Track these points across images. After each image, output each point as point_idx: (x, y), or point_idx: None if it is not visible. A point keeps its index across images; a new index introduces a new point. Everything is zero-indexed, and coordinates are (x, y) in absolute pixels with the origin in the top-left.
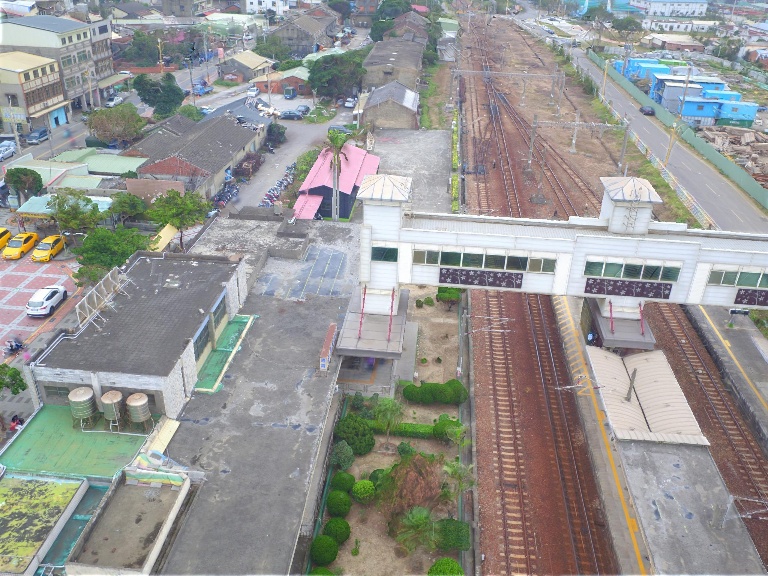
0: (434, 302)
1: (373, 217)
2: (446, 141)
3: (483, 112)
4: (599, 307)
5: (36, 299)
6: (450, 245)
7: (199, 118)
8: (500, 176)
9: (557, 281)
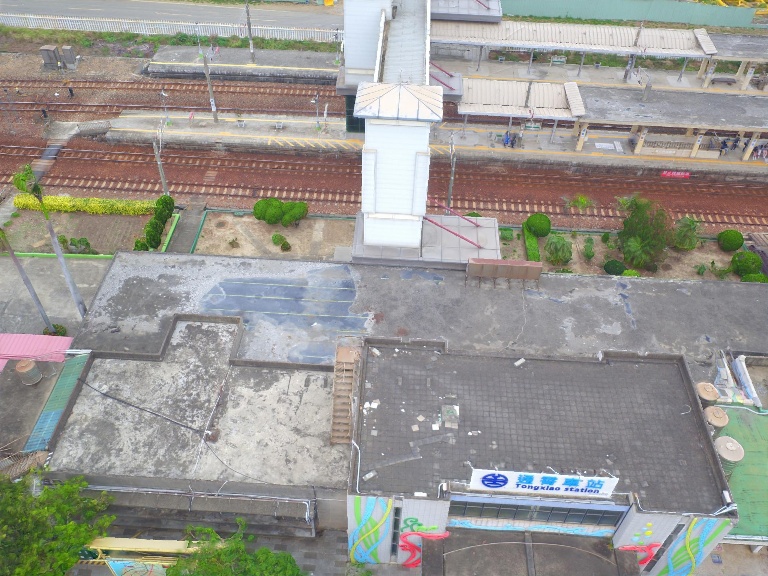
0: None
1: None
2: None
3: None
4: None
5: None
6: None
7: None
8: None
9: None
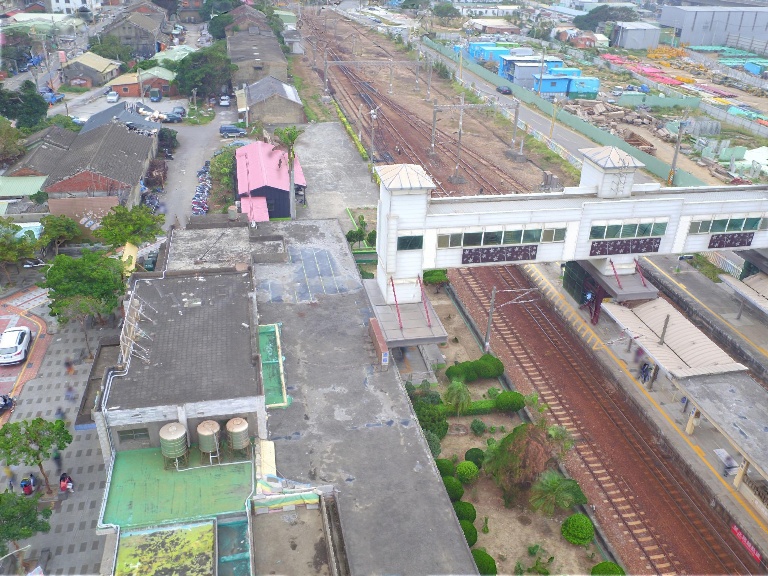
0: None
1: (400, 207)
2: (341, 132)
3: (358, 102)
4: (596, 268)
5: (7, 345)
6: (472, 226)
7: (77, 128)
8: (409, 161)
9: (566, 248)
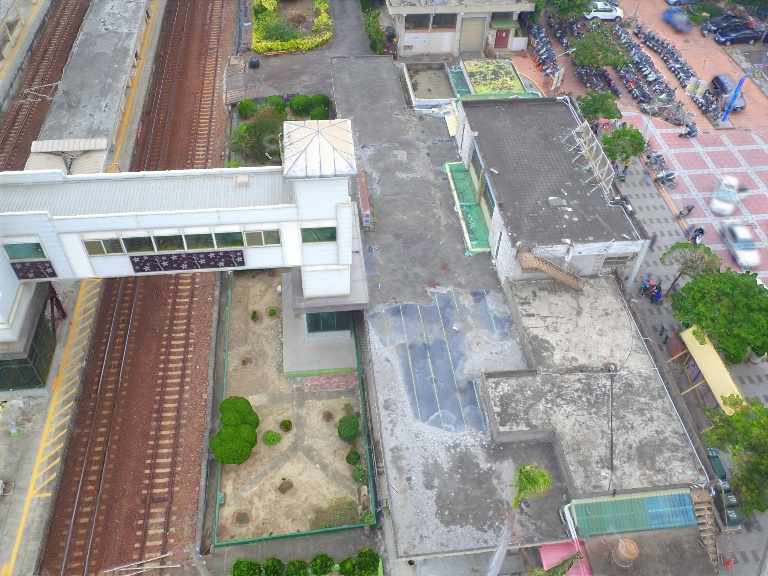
0: (263, 445)
1: None
2: None
3: None
4: None
5: None
6: None
7: None
8: None
9: None
